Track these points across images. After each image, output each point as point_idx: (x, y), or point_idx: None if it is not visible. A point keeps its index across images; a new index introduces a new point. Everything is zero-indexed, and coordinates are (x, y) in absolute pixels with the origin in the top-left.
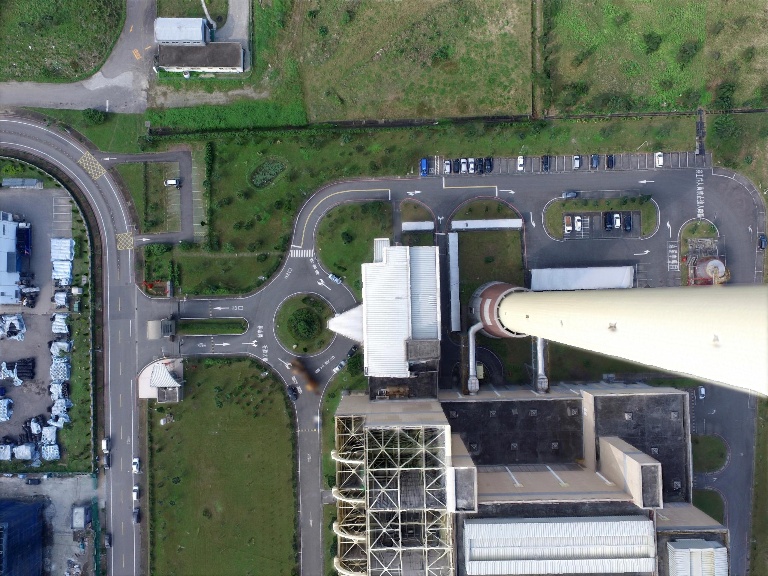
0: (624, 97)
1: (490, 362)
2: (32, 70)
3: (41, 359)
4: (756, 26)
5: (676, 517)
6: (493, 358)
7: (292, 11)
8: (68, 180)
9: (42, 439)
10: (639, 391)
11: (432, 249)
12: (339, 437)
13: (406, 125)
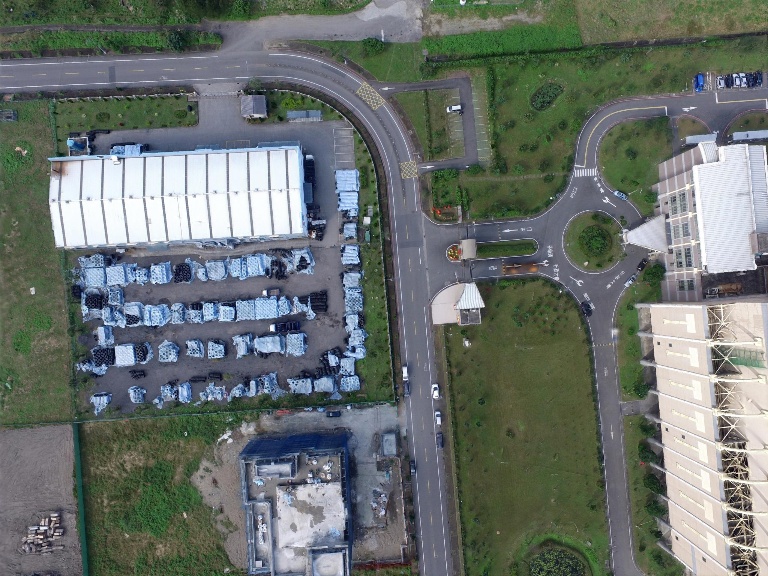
0: None
1: None
2: (305, 2)
3: (332, 291)
4: None
5: None
6: None
7: None
8: (348, 111)
9: (341, 371)
10: None
11: (761, 148)
12: (710, 326)
13: (675, 44)
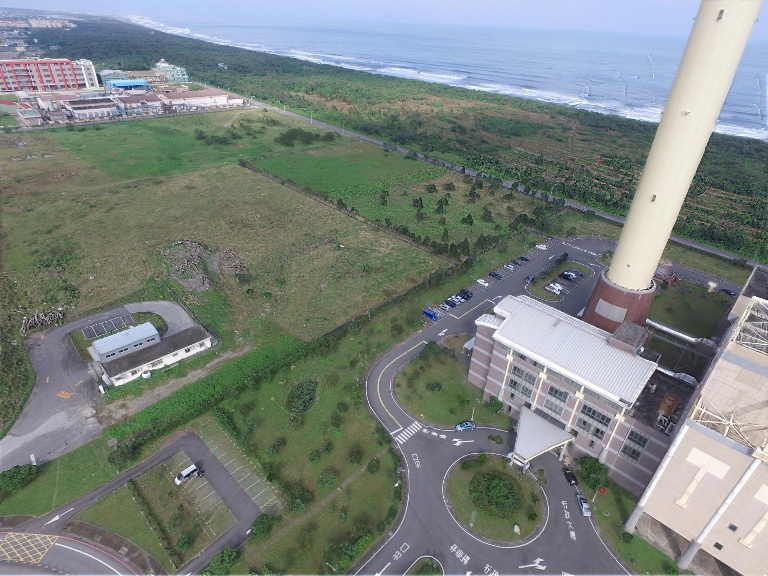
0: None
1: None
2: None
3: None
4: None
5: None
6: None
7: (229, 298)
8: None
9: None
10: None
11: (522, 297)
12: (729, 437)
13: None
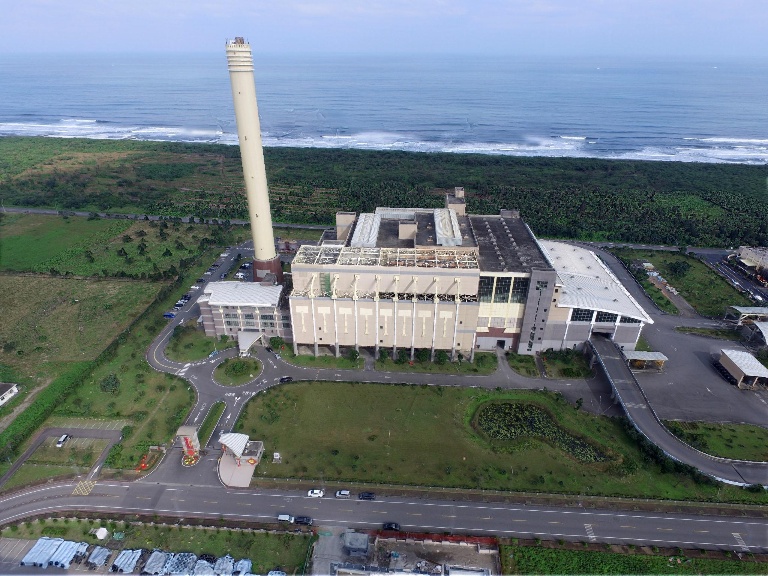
0: None
1: None
2: None
3: None
4: None
5: None
6: None
7: None
8: None
9: None
10: None
11: None
12: None
13: None
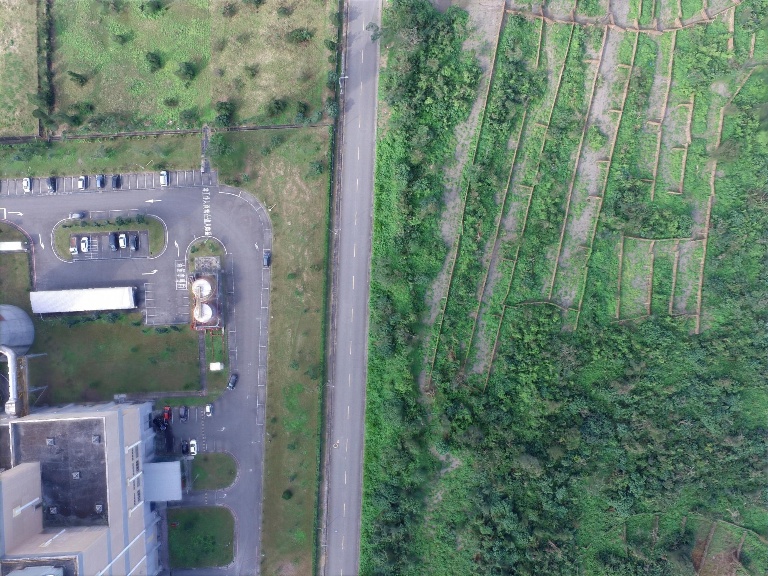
0: (130, 116)
1: (1, 385)
2: None
3: None
4: (260, 42)
5: (60, 543)
6: (4, 381)
7: None
8: None
9: None
10: (68, 416)
11: None
12: None
13: None
